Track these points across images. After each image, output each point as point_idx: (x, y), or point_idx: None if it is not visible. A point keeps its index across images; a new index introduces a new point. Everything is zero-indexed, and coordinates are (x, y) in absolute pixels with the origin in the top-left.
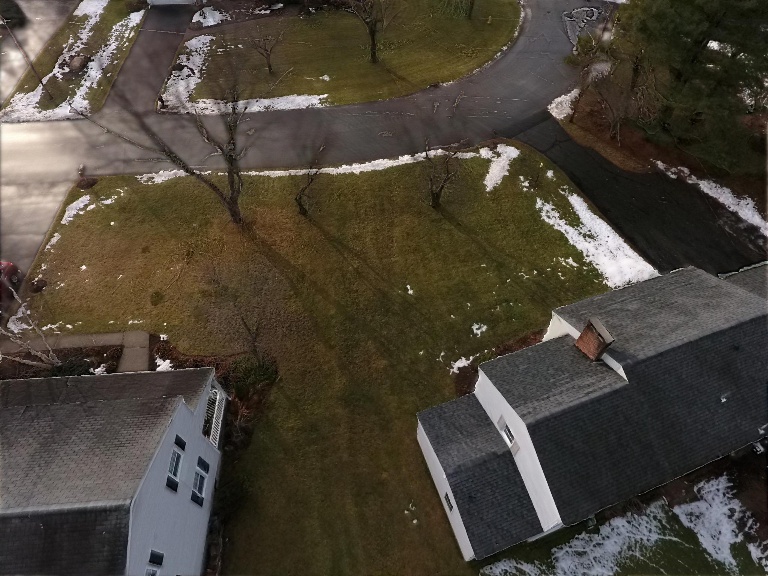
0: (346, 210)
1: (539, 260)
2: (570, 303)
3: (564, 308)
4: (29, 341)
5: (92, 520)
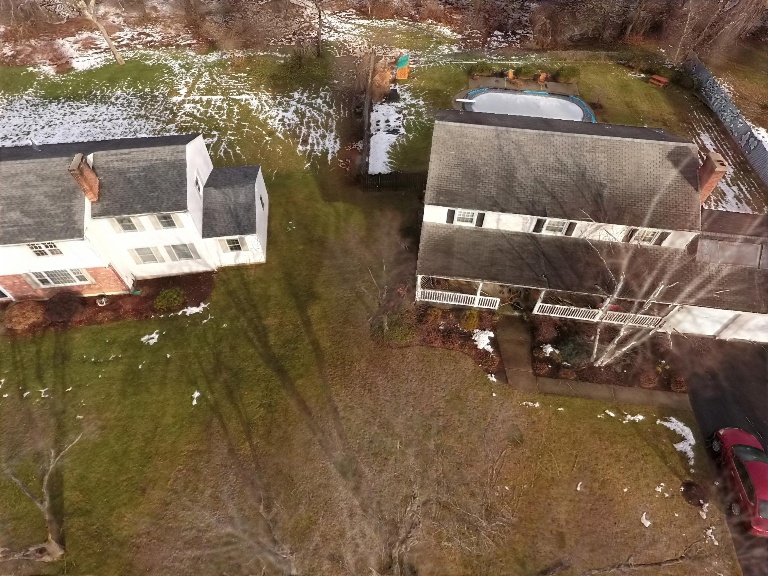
0: (214, 571)
1: (2, 412)
2: (30, 347)
3: (71, 236)
4: (600, 309)
5: None
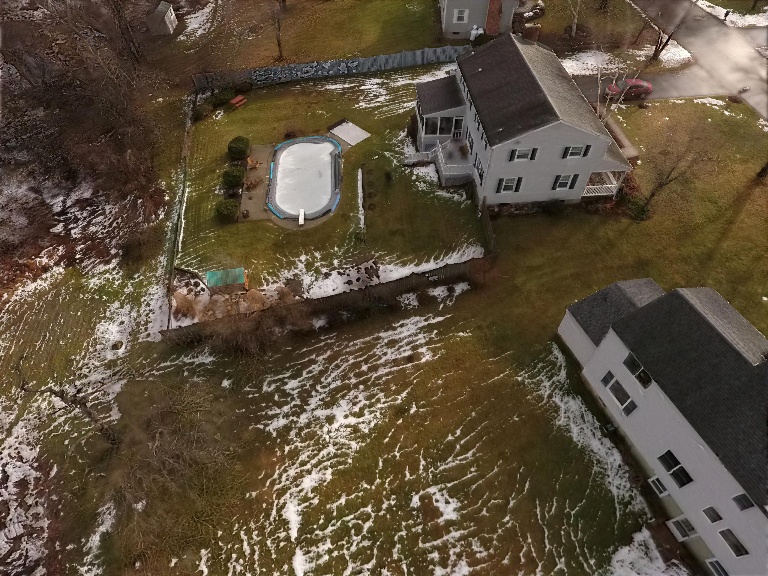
0: None
1: None
2: None
3: None
4: None
5: (550, 113)
